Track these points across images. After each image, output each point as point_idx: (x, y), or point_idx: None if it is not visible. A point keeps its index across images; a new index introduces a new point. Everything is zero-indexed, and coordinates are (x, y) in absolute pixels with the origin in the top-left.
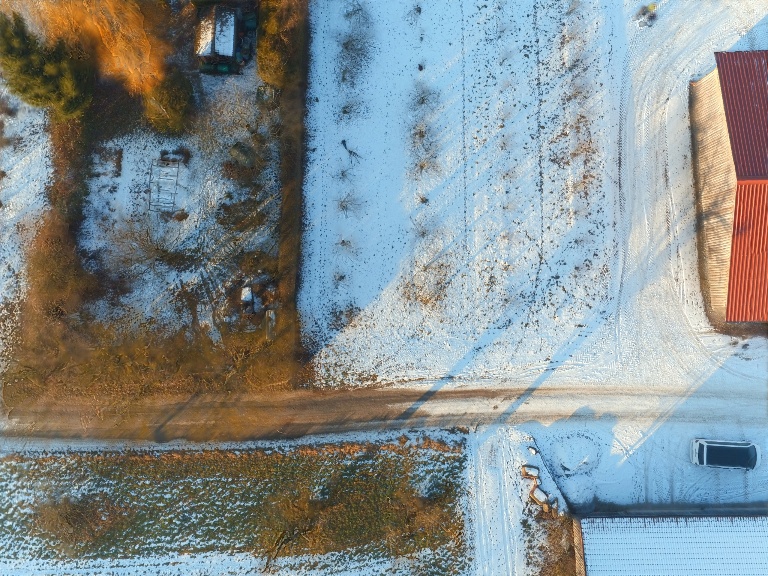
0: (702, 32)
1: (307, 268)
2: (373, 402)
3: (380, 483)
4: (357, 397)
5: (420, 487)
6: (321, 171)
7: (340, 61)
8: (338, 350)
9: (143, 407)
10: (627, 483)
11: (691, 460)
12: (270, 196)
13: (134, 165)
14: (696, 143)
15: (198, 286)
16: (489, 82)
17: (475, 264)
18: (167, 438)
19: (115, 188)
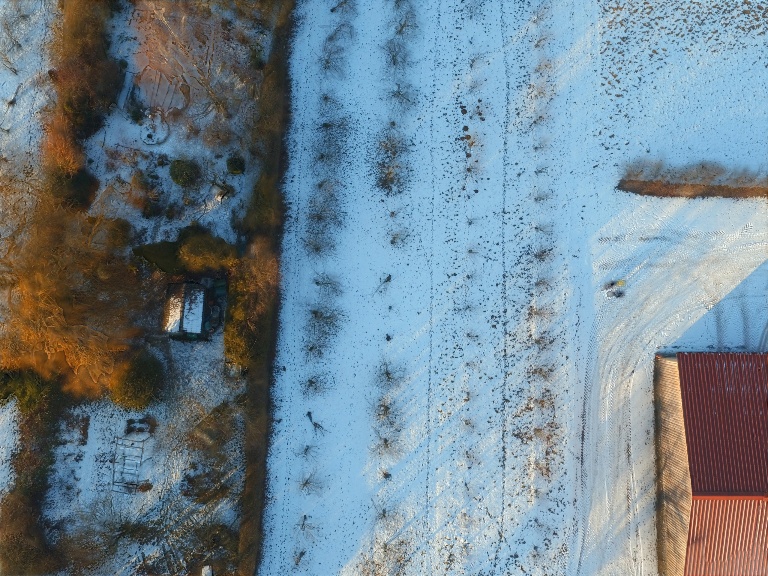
0: (669, 304)
1: (268, 543)
2: None
3: None
4: None
5: None
6: (286, 443)
7: (309, 329)
8: None
9: None
10: None
11: None
12: (234, 468)
13: (101, 434)
14: (659, 419)
15: (160, 559)
16: (456, 353)
17: (435, 541)
18: None
19: (81, 456)
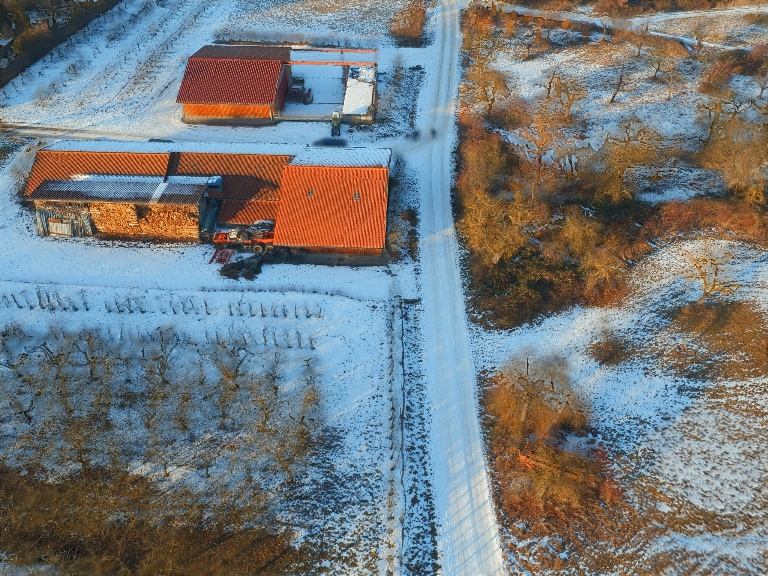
0: None
1: None
2: None
3: None
4: None
5: None
6: None
7: None
8: None
9: None
10: None
11: None
12: None
13: None
14: None
15: None
16: None
17: None
18: None
19: None
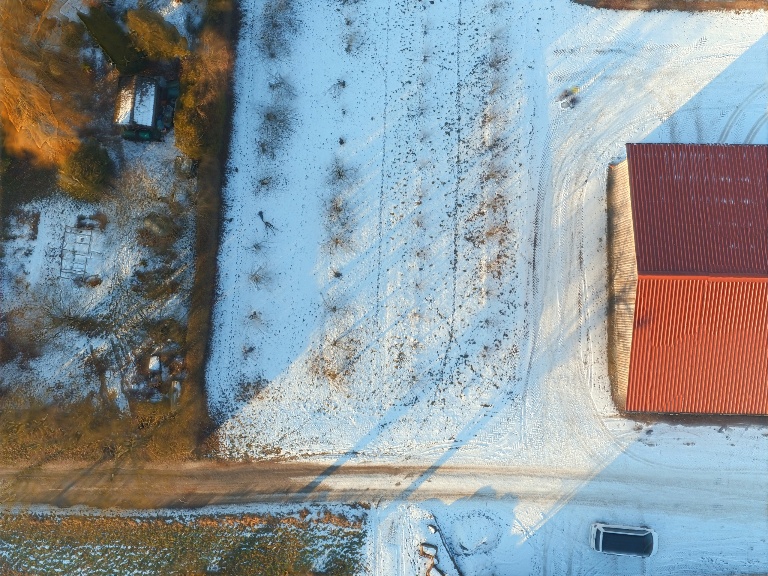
0: (623, 116)
1: (217, 338)
2: (276, 475)
3: (278, 556)
4: (260, 469)
5: (318, 562)
6: (237, 241)
7: (262, 132)
8: (244, 421)
9: (47, 471)
10: (526, 564)
11: (590, 544)
12: (184, 264)
13: (51, 229)
14: (612, 226)
15: (108, 352)
16: (409, 158)
17: (385, 340)
18: (69, 503)
19: (31, 251)
